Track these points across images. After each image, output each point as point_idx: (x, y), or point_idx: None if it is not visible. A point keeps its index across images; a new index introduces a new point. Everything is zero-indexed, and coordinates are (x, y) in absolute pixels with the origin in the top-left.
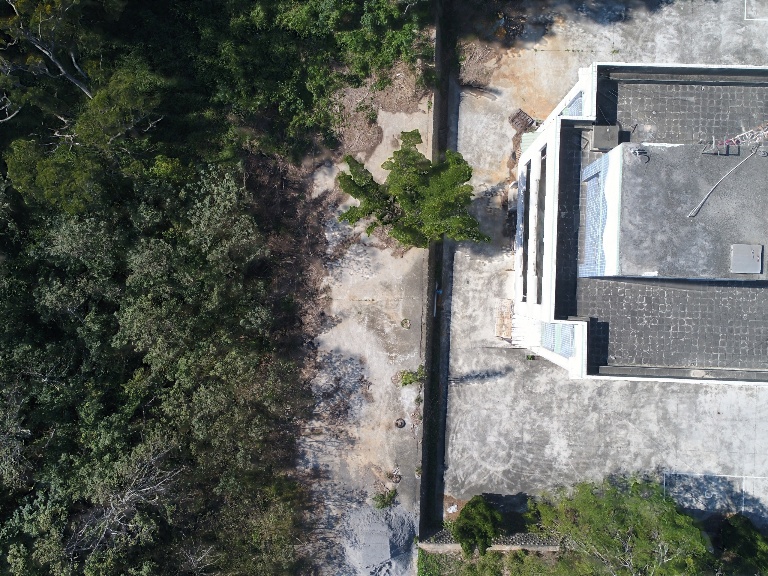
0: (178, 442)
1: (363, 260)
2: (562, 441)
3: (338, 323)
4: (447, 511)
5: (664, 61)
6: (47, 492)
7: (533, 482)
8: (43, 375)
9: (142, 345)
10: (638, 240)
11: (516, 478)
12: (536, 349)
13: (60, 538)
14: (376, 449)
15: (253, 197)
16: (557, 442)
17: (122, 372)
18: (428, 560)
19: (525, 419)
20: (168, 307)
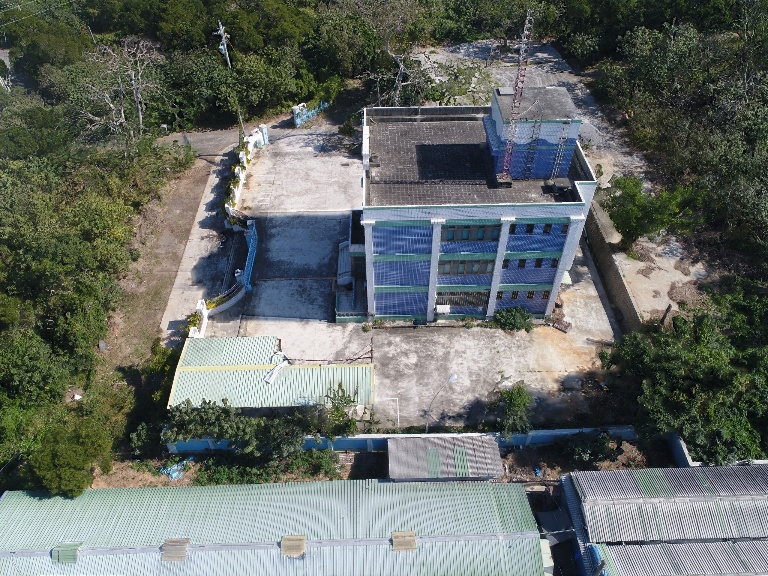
0: None
1: None
2: None
3: None
4: None
5: (460, 367)
6: None
7: None
8: None
9: None
10: (560, 95)
11: None
12: None
13: (764, 91)
14: None
15: (744, 259)
16: None
17: None
18: None
19: None
20: None
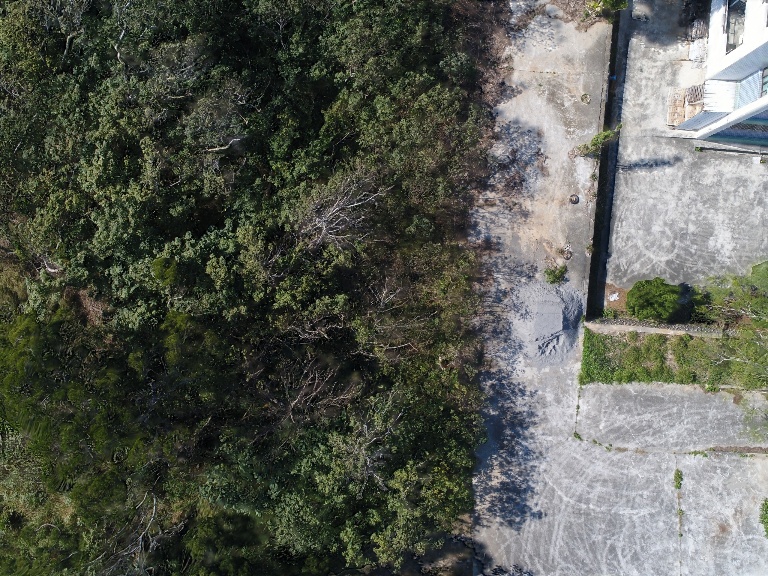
0: (372, 179)
1: (547, 32)
2: (726, 233)
3: (518, 94)
4: (608, 299)
5: None
6: (236, 220)
7: (695, 273)
8: (241, 97)
9: (343, 75)
10: None
11: (679, 268)
12: (723, 120)
13: None
14: (549, 224)
15: None
16: (721, 234)
17: (309, 114)
18: (594, 340)
19: (691, 210)
20: (379, 30)
